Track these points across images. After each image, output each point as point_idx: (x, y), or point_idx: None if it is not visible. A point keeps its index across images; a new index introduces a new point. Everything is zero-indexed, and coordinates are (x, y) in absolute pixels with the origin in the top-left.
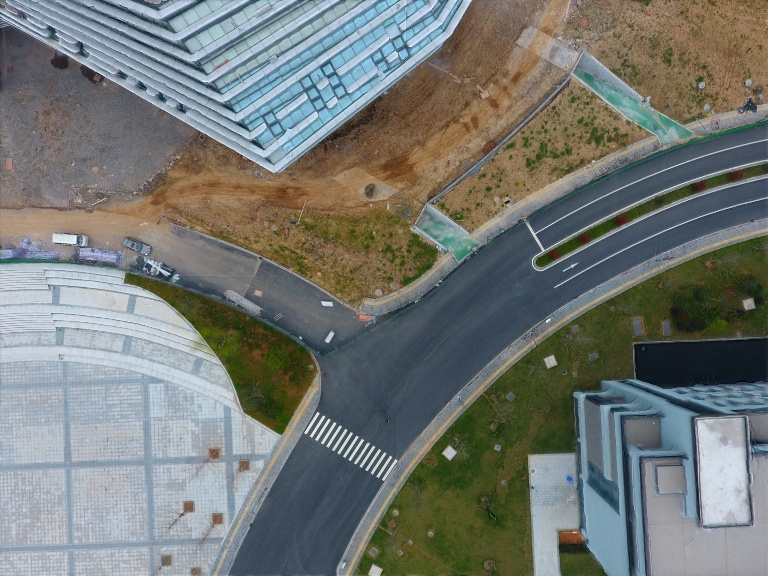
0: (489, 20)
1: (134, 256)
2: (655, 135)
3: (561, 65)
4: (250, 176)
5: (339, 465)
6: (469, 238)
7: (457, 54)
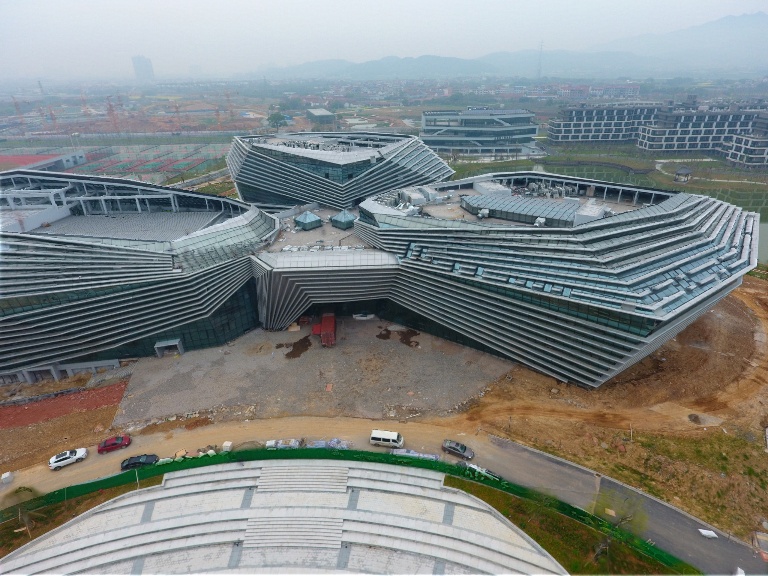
0: (721, 328)
1: (453, 461)
2: None
3: None
4: (564, 404)
5: None
6: None
7: (710, 342)
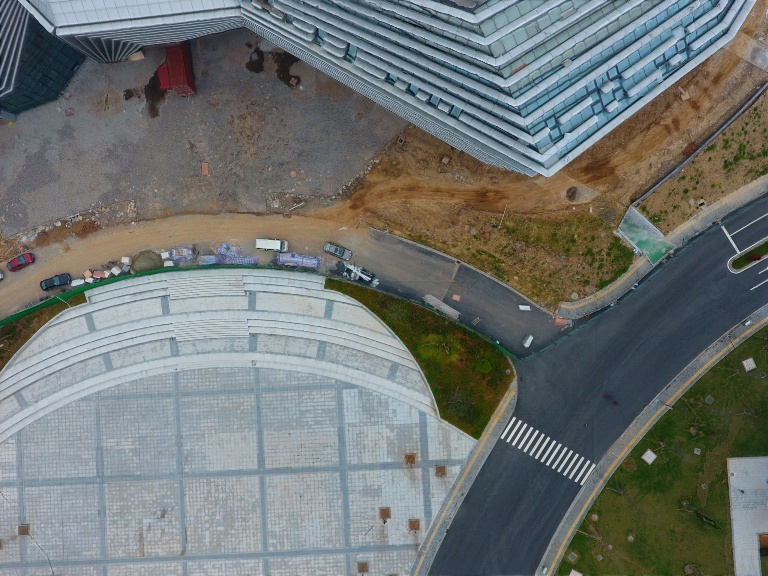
0: None
1: (333, 261)
2: None
3: (762, 66)
4: (450, 180)
5: (536, 470)
6: (663, 241)
7: None
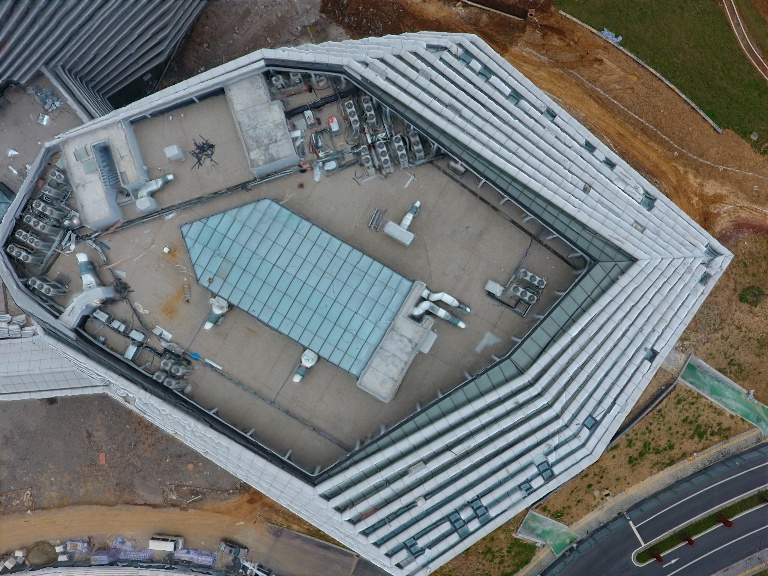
0: None
1: (230, 556)
2: (758, 427)
3: (668, 367)
4: None
5: None
6: (568, 531)
7: None
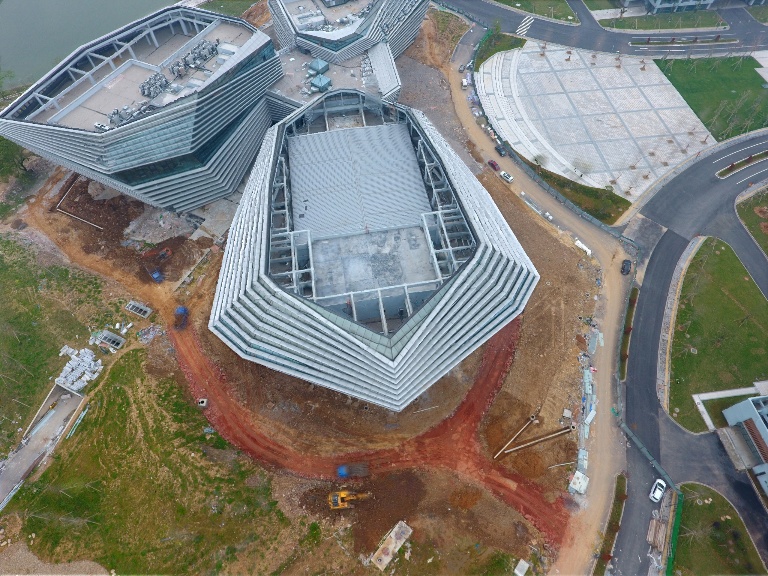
0: None
1: None
2: None
3: None
4: (426, 45)
5: (534, 27)
6: (437, 7)
7: None
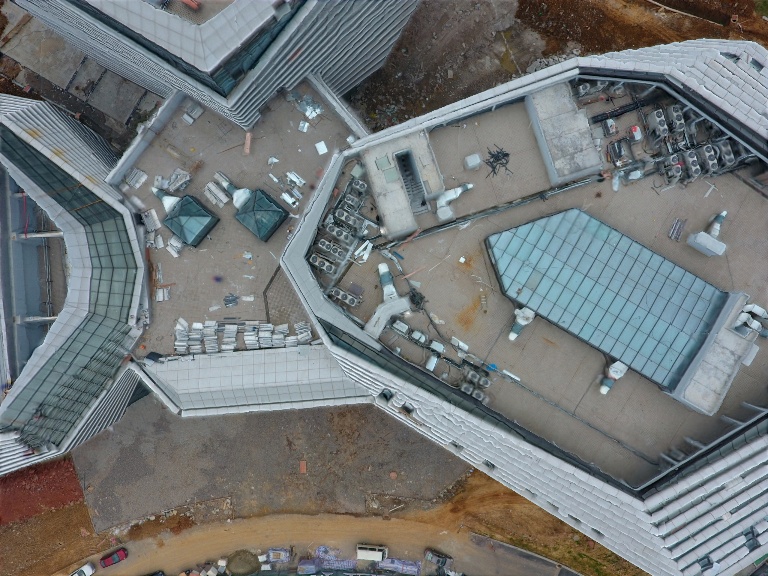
0: None
1: (433, 566)
2: None
3: None
4: None
5: None
6: None
7: None
